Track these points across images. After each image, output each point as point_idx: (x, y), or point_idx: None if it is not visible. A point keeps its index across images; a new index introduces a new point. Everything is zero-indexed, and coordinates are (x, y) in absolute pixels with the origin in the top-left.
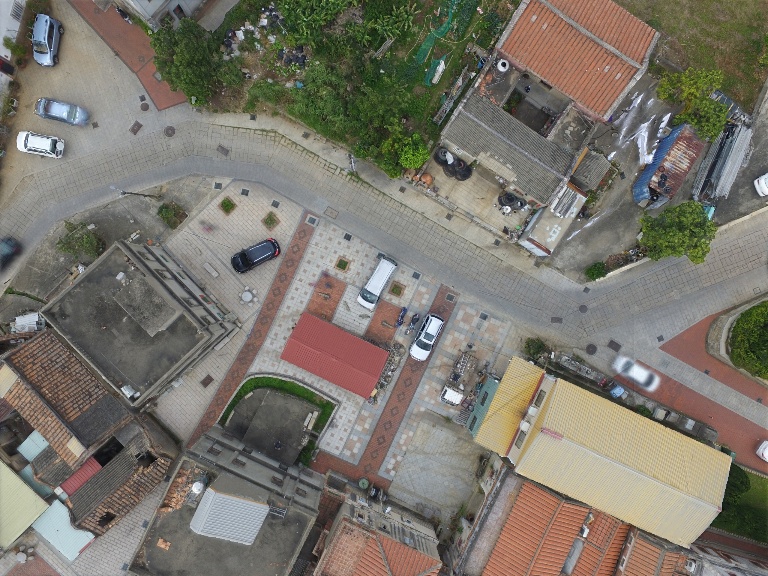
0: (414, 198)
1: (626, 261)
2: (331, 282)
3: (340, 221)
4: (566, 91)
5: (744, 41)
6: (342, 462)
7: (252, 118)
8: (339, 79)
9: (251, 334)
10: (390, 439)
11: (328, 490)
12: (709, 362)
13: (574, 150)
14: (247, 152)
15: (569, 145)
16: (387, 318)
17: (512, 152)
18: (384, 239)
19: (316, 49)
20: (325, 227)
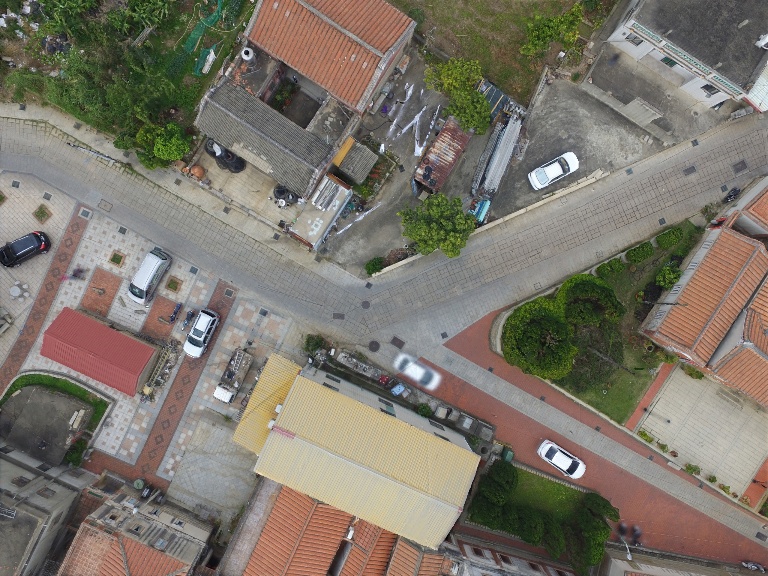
0: (190, 191)
1: (406, 256)
2: (106, 277)
3: (114, 214)
4: (318, 80)
5: (520, 32)
6: (118, 462)
7: (22, 108)
8: (94, 68)
9: (23, 330)
10: (168, 438)
11: (89, 491)
12: (493, 359)
13: (334, 141)
14: (17, 143)
15: (329, 136)
16: (164, 314)
17: (264, 143)
18: (160, 233)
19: (78, 37)
20: (99, 220)
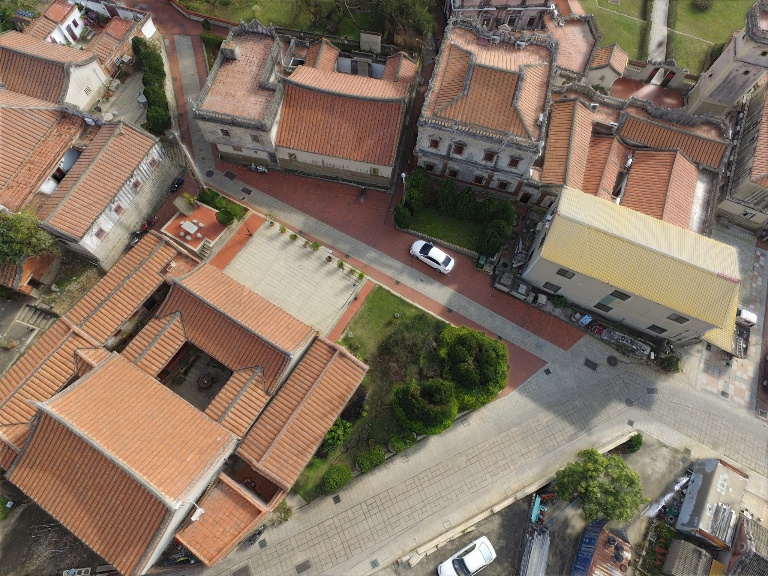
0: None
1: None
2: None
3: None
4: None
5: None
6: None
7: None
8: None
9: None
10: None
11: None
12: None
13: None
14: None
15: None
16: None
17: None
18: None
19: None
20: None
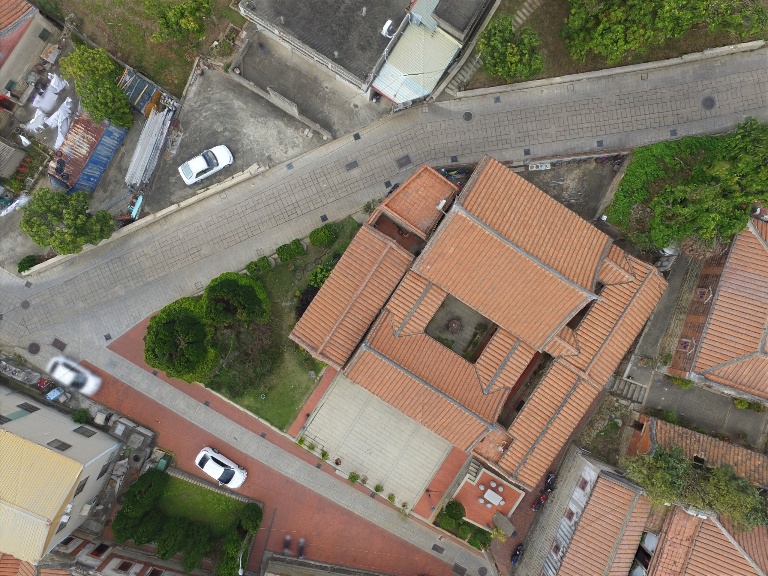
0: None
1: None
2: None
3: None
4: None
5: None
6: None
7: None
8: None
9: None
10: None
11: None
12: None
13: None
14: None
15: None
16: None
17: None
18: None
19: None
20: None
